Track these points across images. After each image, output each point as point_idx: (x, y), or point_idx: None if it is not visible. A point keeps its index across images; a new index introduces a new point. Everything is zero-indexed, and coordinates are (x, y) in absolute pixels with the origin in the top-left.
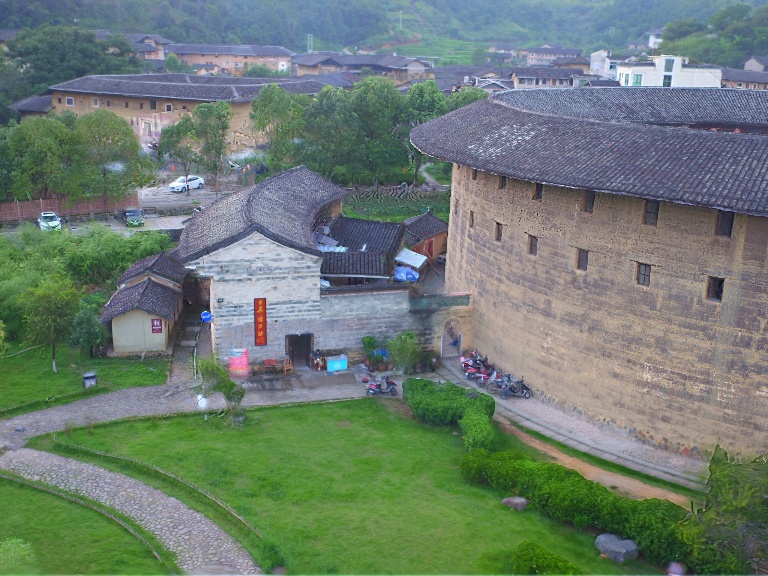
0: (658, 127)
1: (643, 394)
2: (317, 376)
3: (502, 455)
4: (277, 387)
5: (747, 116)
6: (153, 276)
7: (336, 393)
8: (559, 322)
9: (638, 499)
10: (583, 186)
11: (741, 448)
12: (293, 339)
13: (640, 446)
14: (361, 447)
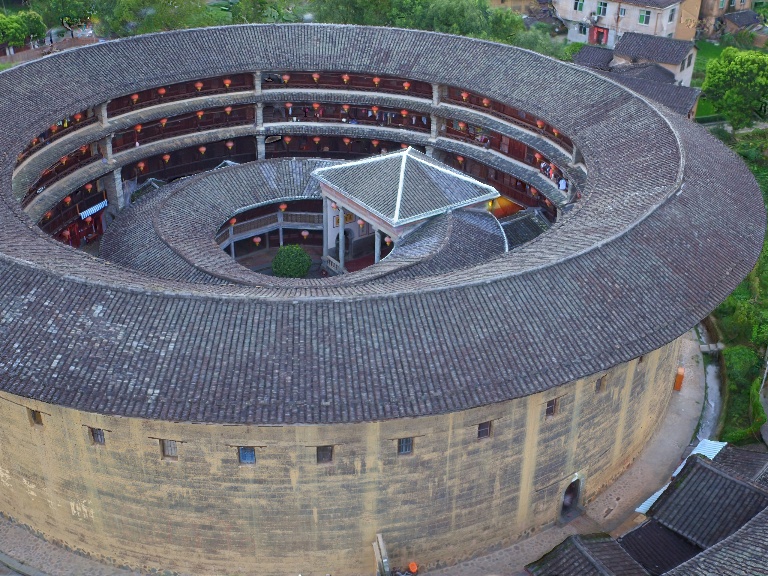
0: None
1: None
2: None
3: None
4: None
5: (495, 87)
6: None
7: None
8: None
9: None
10: None
11: None
12: None
13: None
14: None
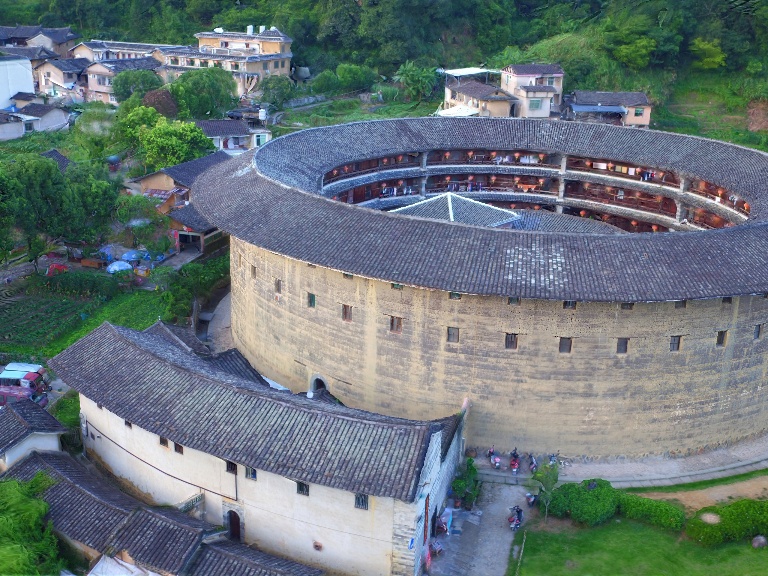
0: (658, 234)
1: (676, 426)
2: (458, 541)
3: (707, 516)
4: (463, 572)
5: (349, 154)
6: (204, 539)
7: (497, 546)
8: (602, 398)
9: (750, 497)
10: (687, 298)
11: (732, 433)
12: (432, 519)
13: (677, 462)
14: (626, 573)
